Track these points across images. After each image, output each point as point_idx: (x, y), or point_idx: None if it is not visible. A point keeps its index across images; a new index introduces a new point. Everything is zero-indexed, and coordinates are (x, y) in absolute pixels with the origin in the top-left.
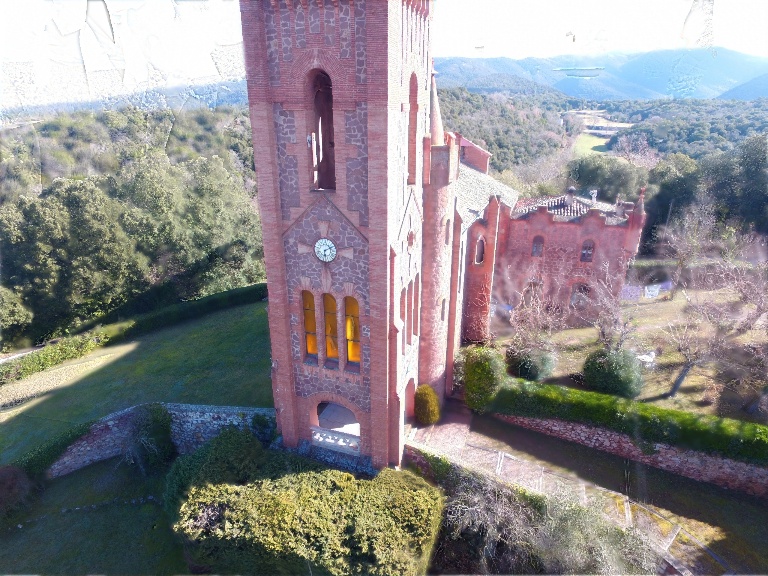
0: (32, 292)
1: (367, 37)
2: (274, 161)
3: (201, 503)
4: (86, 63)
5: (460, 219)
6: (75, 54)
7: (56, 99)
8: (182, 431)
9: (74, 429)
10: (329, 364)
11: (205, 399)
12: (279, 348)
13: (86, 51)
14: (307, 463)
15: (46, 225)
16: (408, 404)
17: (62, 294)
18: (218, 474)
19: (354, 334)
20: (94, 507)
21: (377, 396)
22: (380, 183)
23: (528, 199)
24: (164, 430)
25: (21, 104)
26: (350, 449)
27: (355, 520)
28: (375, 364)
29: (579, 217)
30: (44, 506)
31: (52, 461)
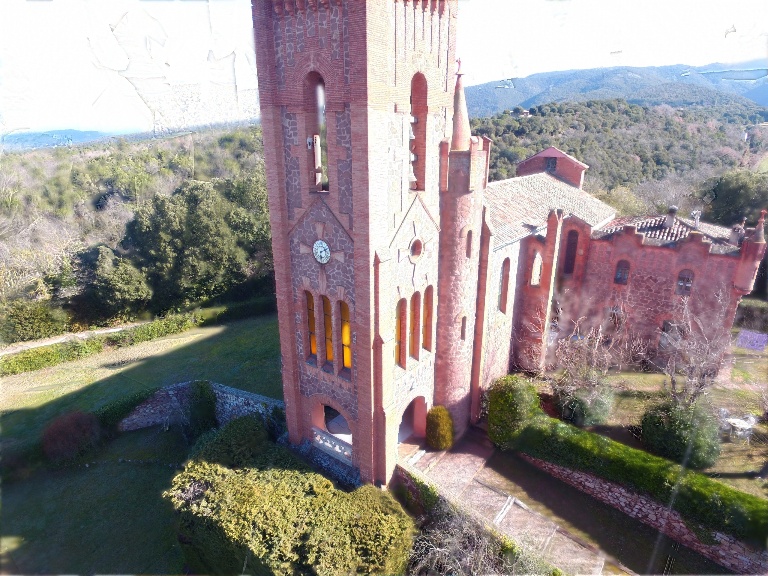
0: (155, 274)
1: (349, 36)
2: (281, 162)
3: (191, 477)
4: (238, 83)
5: (489, 232)
6: (230, 76)
7: (211, 114)
8: (223, 411)
9: (142, 392)
10: (326, 367)
11: (250, 385)
12: (285, 344)
13: (239, 73)
14: (296, 462)
15: (168, 218)
16: (420, 424)
17: (175, 278)
18: (216, 454)
19: (350, 340)
20: (141, 463)
21: (363, 407)
22: (362, 186)
23: (624, 218)
24: (209, 407)
25: None
26: (345, 457)
27: (314, 529)
28: (361, 373)
29: (676, 242)
30: (108, 453)
31: (123, 416)
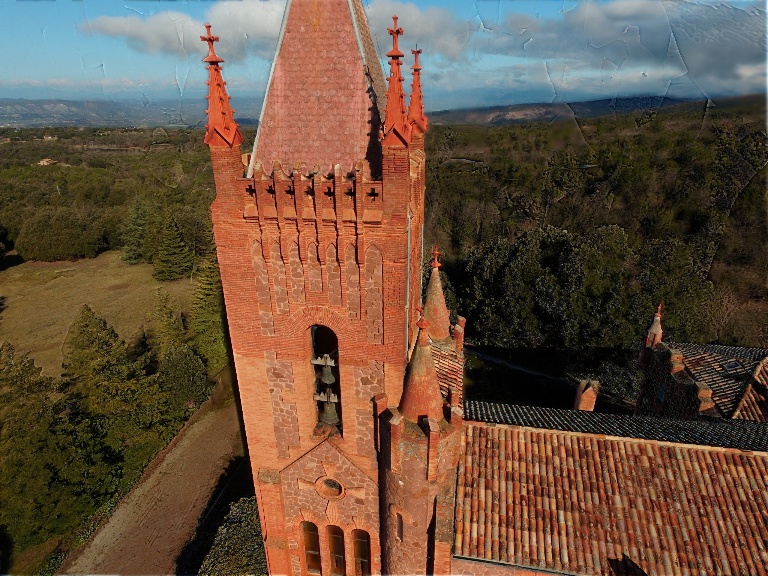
0: None
1: None
2: None
3: None
4: None
5: (435, 532)
6: None
7: (657, 137)
8: None
9: None
10: None
11: None
12: None
13: None
14: None
15: None
16: None
17: None
18: None
19: None
20: None
21: None
22: None
23: None
24: None
25: (618, 142)
26: None
27: None
28: None
29: None
30: None
31: None
